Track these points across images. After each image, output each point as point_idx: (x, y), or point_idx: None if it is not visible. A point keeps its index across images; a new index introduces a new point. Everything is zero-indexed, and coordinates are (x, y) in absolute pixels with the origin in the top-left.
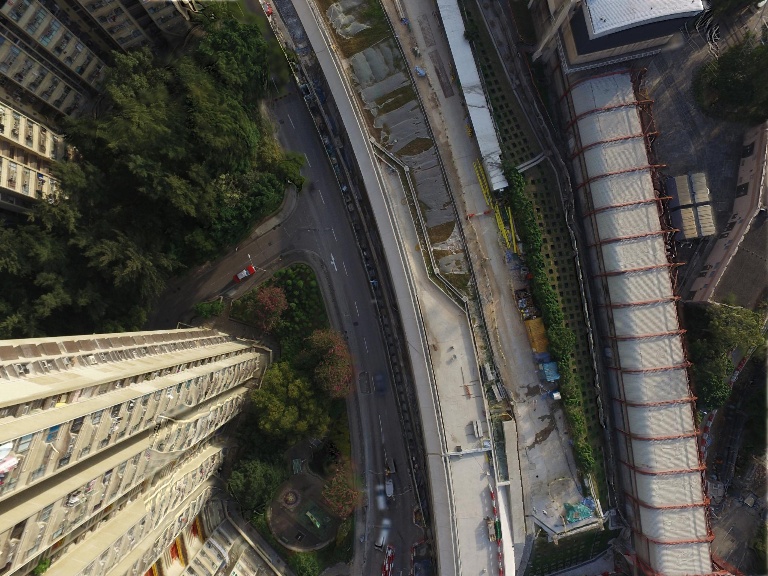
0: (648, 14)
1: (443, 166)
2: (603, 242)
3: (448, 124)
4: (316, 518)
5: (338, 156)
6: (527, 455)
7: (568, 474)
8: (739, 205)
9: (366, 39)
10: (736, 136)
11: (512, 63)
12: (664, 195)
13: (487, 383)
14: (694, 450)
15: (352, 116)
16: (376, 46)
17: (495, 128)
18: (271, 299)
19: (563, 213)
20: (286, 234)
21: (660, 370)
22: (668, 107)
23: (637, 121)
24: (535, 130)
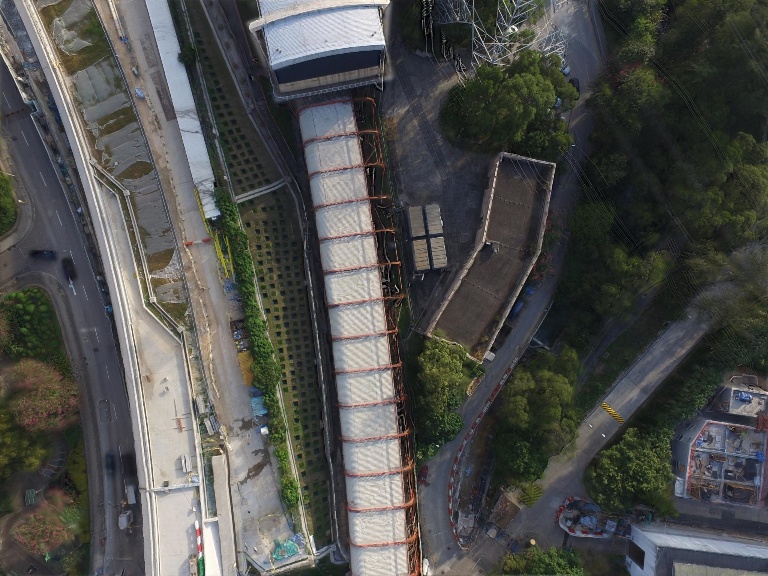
0: (319, 47)
1: (162, 191)
2: (324, 273)
3: (169, 148)
4: (48, 551)
5: (69, 176)
6: (239, 490)
7: (279, 510)
8: (478, 237)
9: (88, 57)
10: (482, 167)
11: (247, 86)
12: (382, 227)
13: (201, 416)
14: (399, 487)
15: (72, 136)
16: (98, 64)
17: (211, 154)
18: (1, 323)
19: (301, 241)
20: (22, 255)
21: (369, 405)
22: (415, 136)
23: (355, 152)
24: (274, 156)
